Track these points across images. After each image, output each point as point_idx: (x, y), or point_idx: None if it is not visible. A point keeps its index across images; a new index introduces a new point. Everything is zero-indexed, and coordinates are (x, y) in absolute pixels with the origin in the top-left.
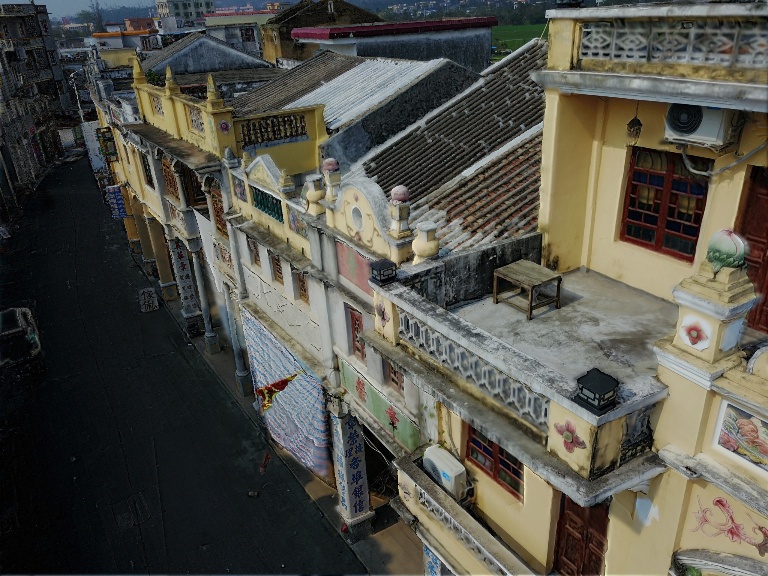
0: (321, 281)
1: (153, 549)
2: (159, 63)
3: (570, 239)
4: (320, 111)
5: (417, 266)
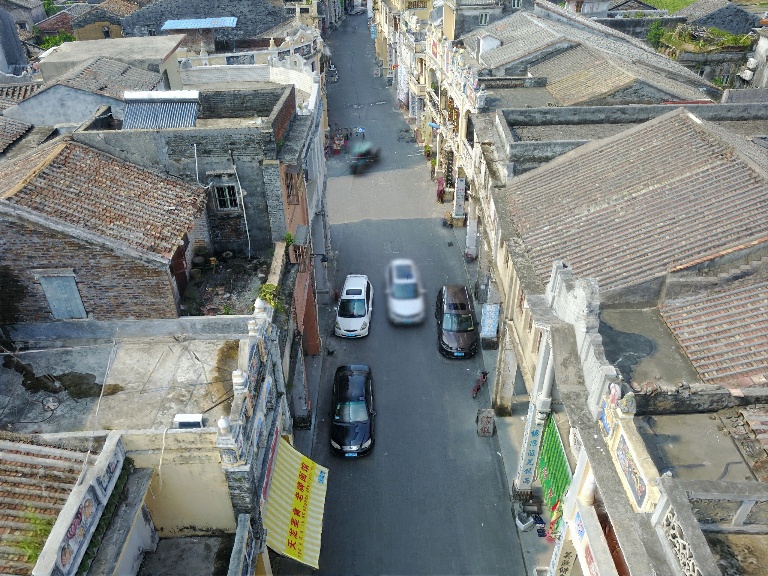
0: None
1: (362, 118)
2: None
3: (449, 33)
4: (432, 1)
5: None
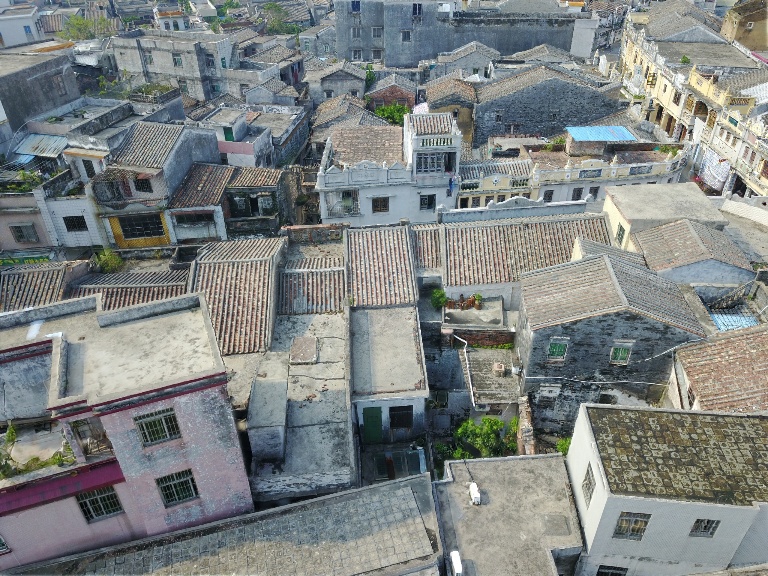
0: (742, 141)
1: None
2: (671, 35)
3: None
4: (755, 99)
5: (765, 138)
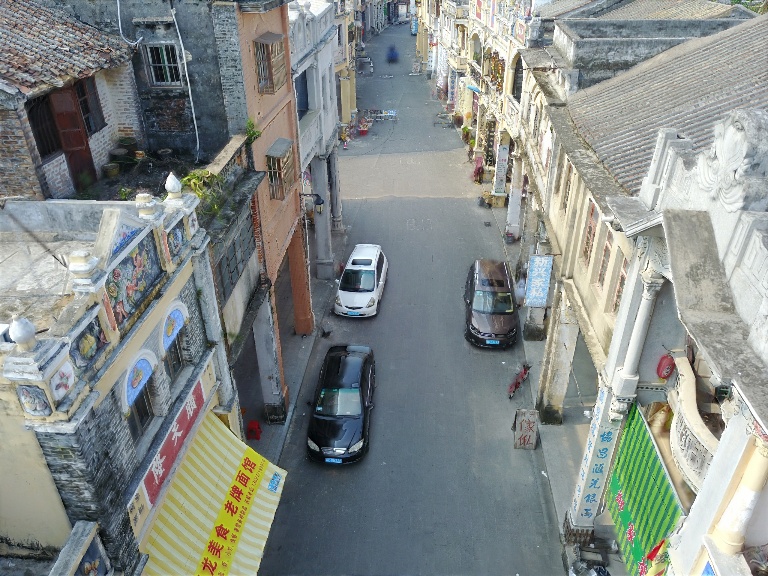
0: None
1: None
2: None
3: None
4: None
5: None
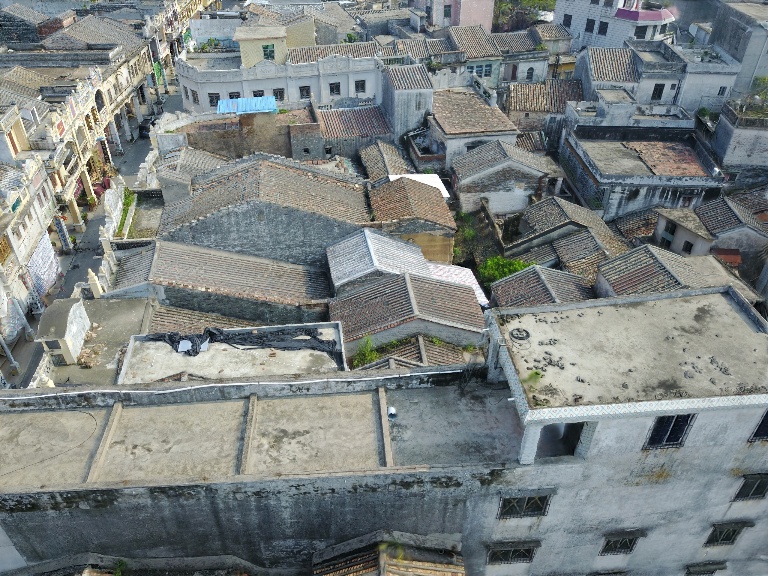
0: None
1: None
2: None
3: None
4: None
5: None
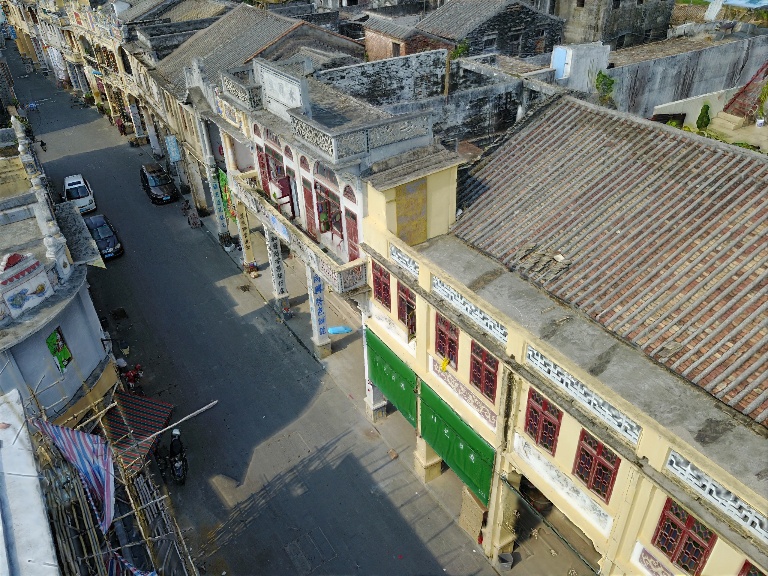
0: None
1: None
2: None
3: None
4: None
5: None
